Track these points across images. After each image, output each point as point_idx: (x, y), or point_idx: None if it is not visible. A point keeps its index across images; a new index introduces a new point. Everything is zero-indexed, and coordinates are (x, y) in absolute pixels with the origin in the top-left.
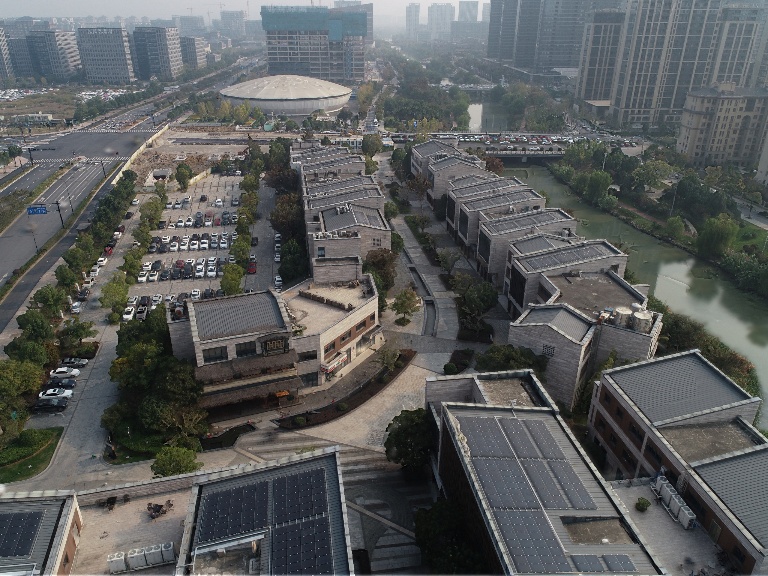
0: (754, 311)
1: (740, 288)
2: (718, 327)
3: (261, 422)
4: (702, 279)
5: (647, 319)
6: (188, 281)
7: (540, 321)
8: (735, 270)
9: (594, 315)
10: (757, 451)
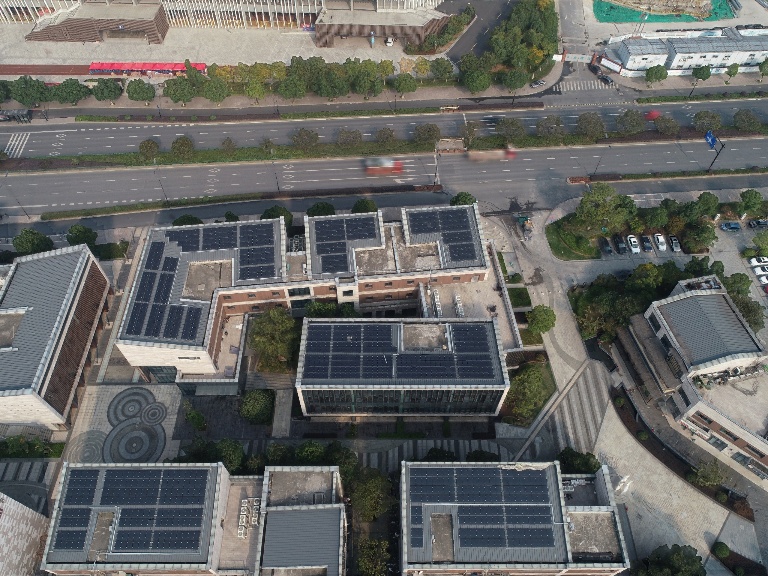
0: None
1: None
2: None
3: (619, 375)
4: None
5: None
6: None
7: None
8: None
9: None
10: None
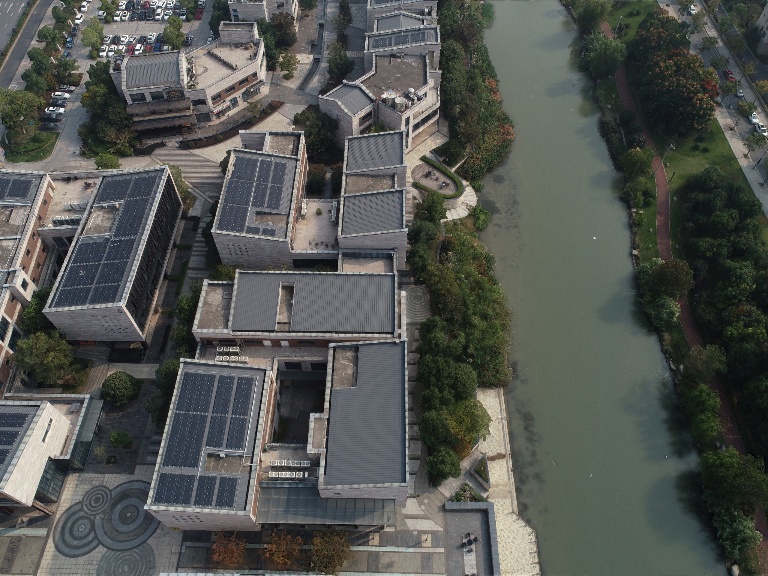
0: (570, 90)
1: (581, 67)
2: (527, 102)
3: (170, 142)
4: (559, 55)
5: (400, 103)
6: (150, 23)
7: (338, 96)
8: (589, 49)
9: (382, 94)
10: (379, 193)
